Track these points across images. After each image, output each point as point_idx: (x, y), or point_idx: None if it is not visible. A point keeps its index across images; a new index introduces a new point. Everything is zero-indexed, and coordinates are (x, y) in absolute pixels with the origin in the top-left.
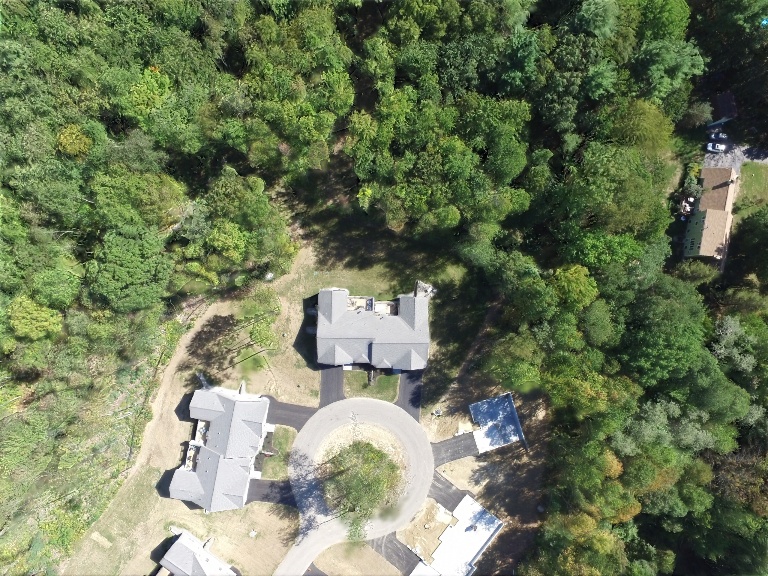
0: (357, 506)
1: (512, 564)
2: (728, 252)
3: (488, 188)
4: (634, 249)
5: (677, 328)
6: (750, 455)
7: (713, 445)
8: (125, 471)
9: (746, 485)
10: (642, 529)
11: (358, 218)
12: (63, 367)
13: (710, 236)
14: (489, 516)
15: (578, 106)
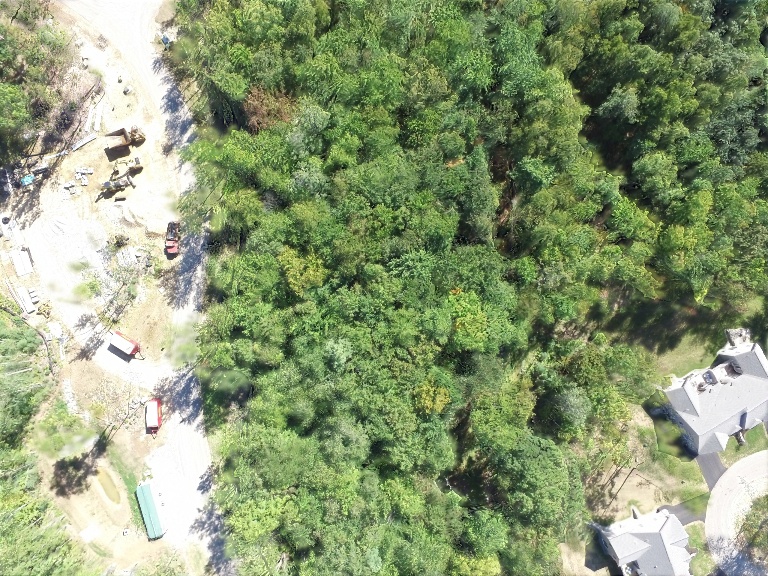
0: None
1: None
2: None
3: None
4: None
5: None
6: None
7: None
8: None
9: None
10: None
11: (648, 306)
12: None
13: None
14: None
15: None
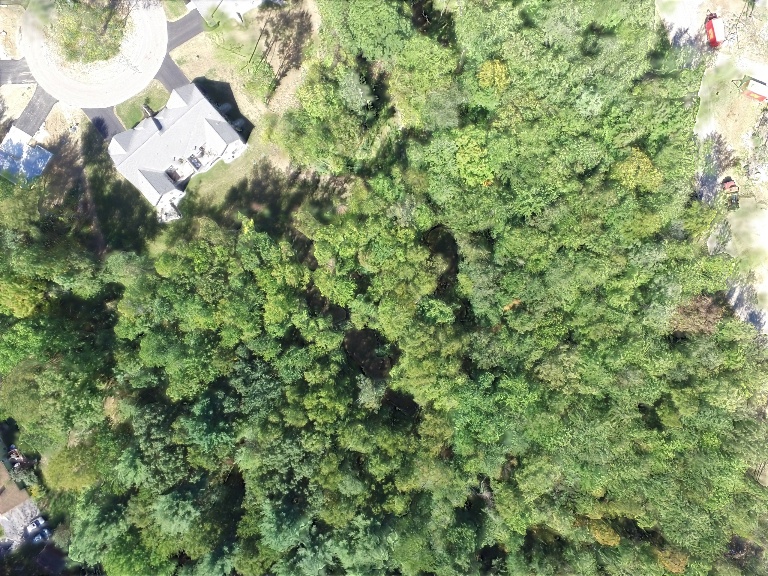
0: (71, 3)
1: None
2: None
3: (156, 314)
4: None
5: None
6: None
7: None
8: None
9: None
10: None
11: None
12: None
13: None
14: None
15: None
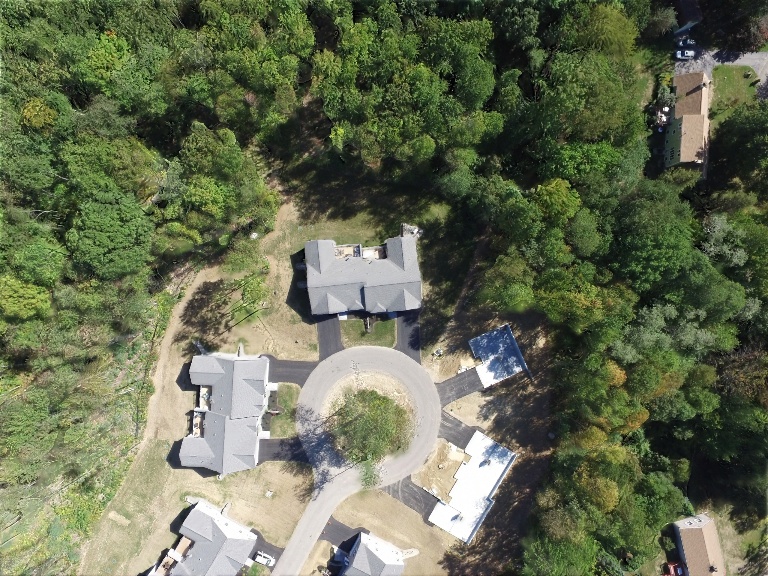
0: (369, 454)
1: (529, 494)
2: (709, 157)
3: (460, 113)
4: (612, 156)
5: (664, 227)
6: (751, 350)
7: (713, 344)
8: (134, 447)
9: (750, 379)
10: (654, 443)
11: (336, 167)
12: (56, 342)
13: (689, 142)
14: (501, 449)
15: (540, 17)
